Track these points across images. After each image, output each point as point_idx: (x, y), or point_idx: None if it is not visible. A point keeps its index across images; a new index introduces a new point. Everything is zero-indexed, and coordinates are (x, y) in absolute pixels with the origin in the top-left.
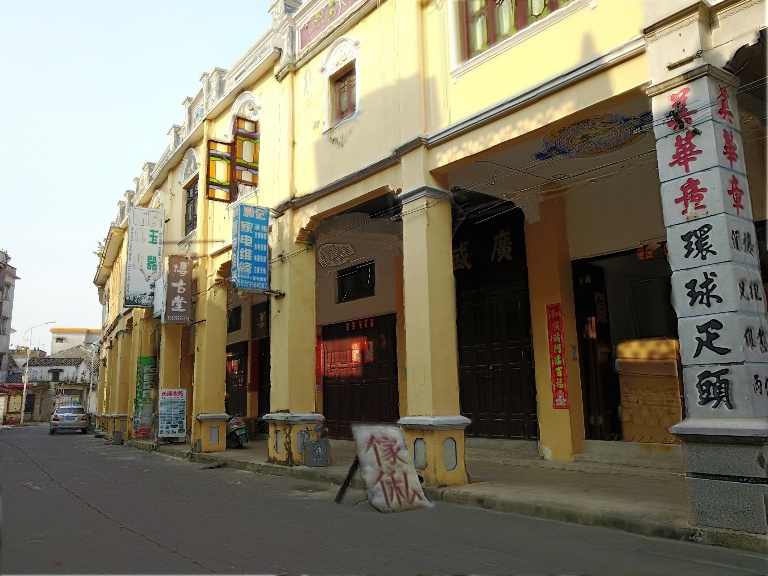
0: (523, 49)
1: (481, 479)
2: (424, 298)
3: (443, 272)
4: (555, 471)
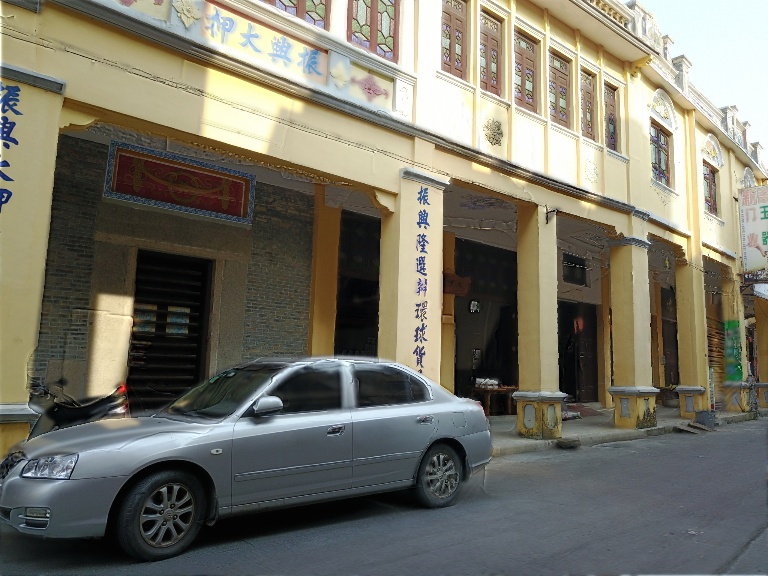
0: None
1: None
2: None
3: None
4: None
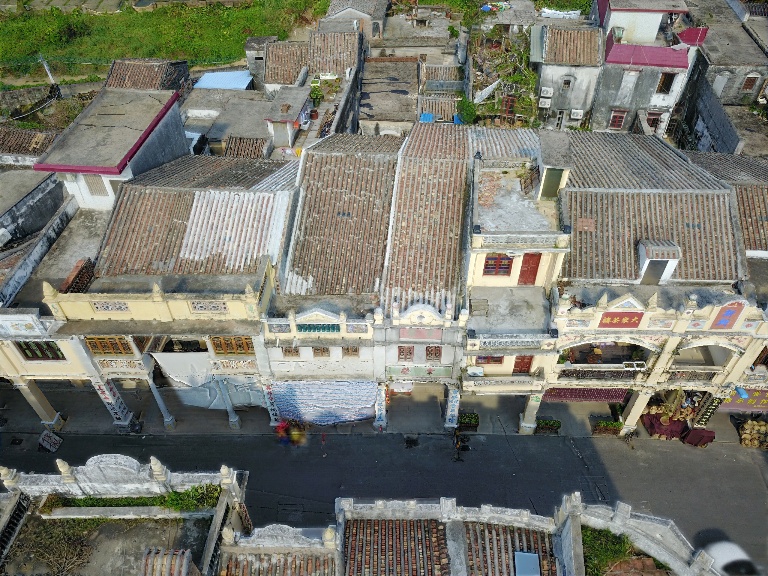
0: (50, 365)
1: (66, 415)
2: (37, 403)
3: (38, 394)
4: (81, 394)
